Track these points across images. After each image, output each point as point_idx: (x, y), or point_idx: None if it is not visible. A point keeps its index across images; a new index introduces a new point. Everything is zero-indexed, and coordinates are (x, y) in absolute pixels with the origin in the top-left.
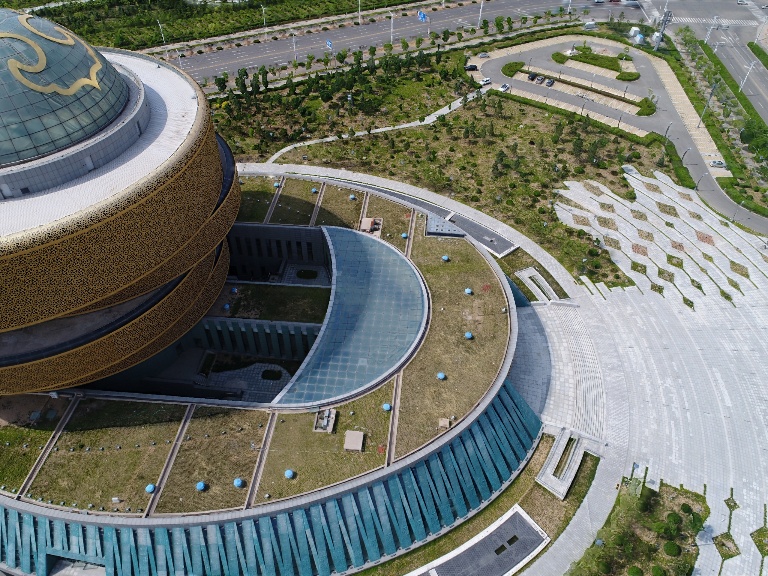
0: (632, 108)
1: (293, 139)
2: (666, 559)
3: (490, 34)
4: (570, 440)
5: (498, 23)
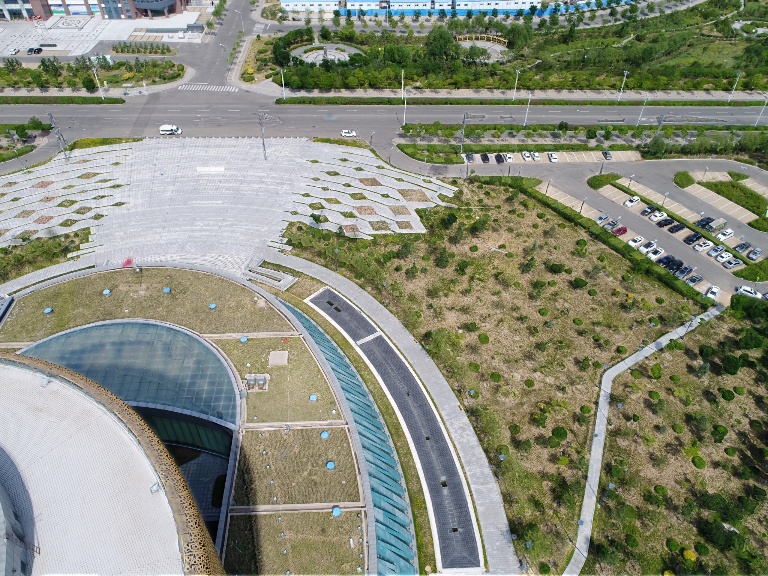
0: None
1: None
2: (333, 241)
3: None
4: None
5: None
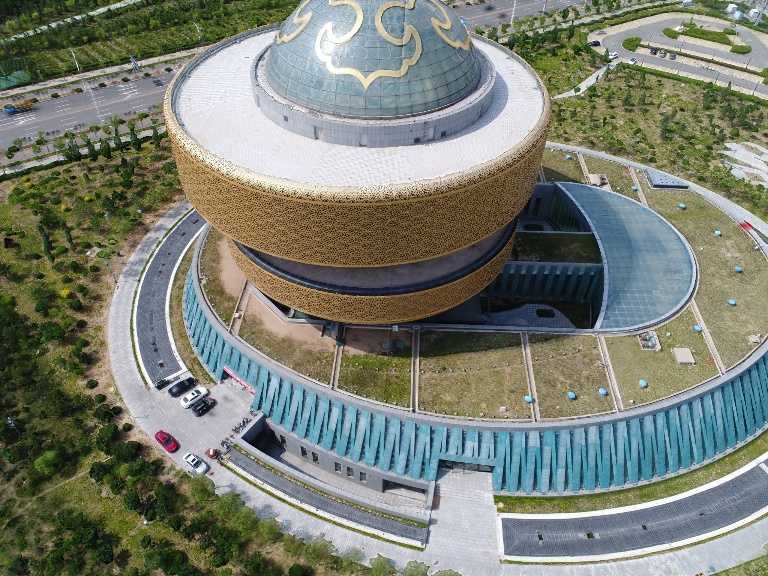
0: (756, 78)
1: None
2: None
3: None
4: None
5: None
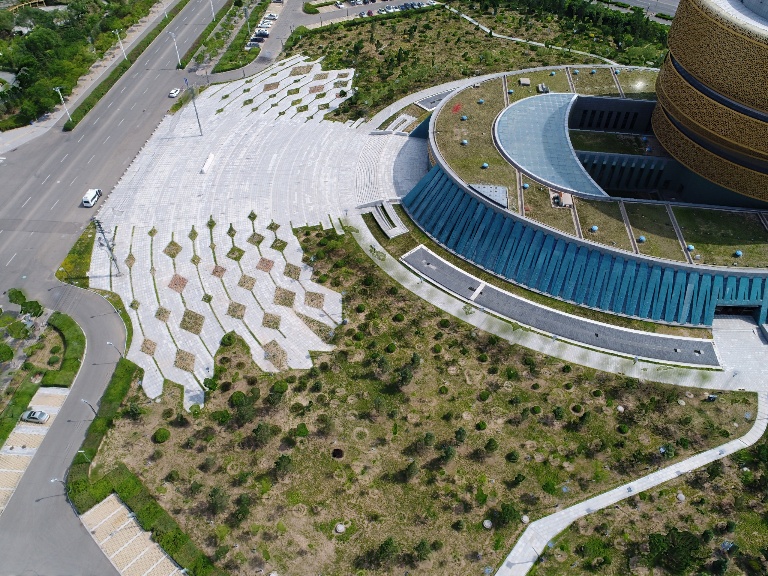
0: None
1: None
2: None
3: None
4: None
5: None
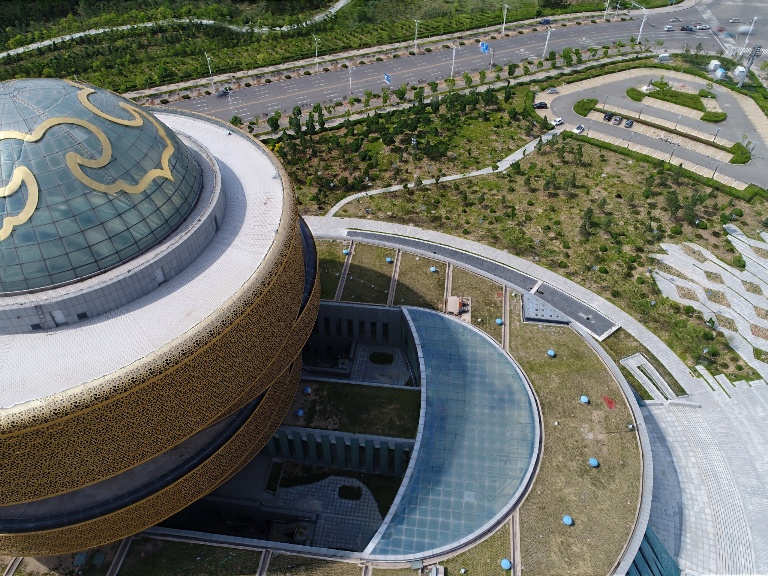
0: (724, 155)
1: (353, 188)
2: None
3: (556, 66)
4: None
5: (567, 55)
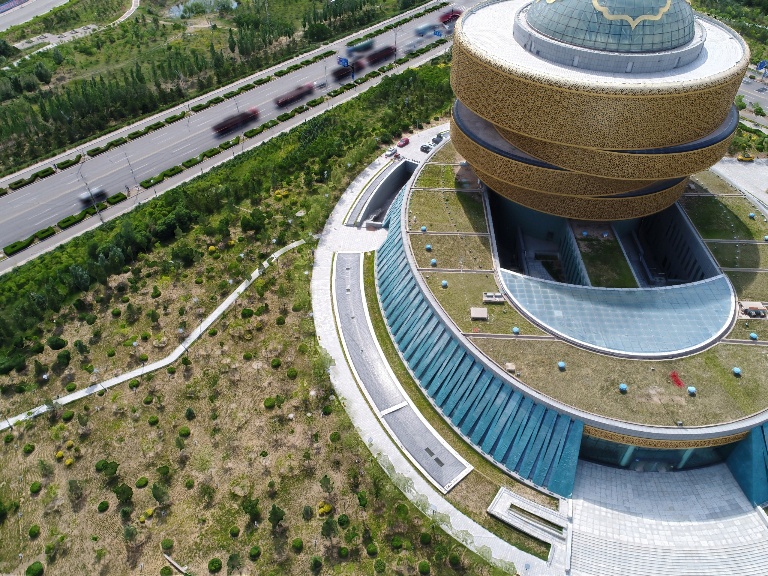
0: None
1: None
2: None
3: None
4: (559, 527)
5: None
